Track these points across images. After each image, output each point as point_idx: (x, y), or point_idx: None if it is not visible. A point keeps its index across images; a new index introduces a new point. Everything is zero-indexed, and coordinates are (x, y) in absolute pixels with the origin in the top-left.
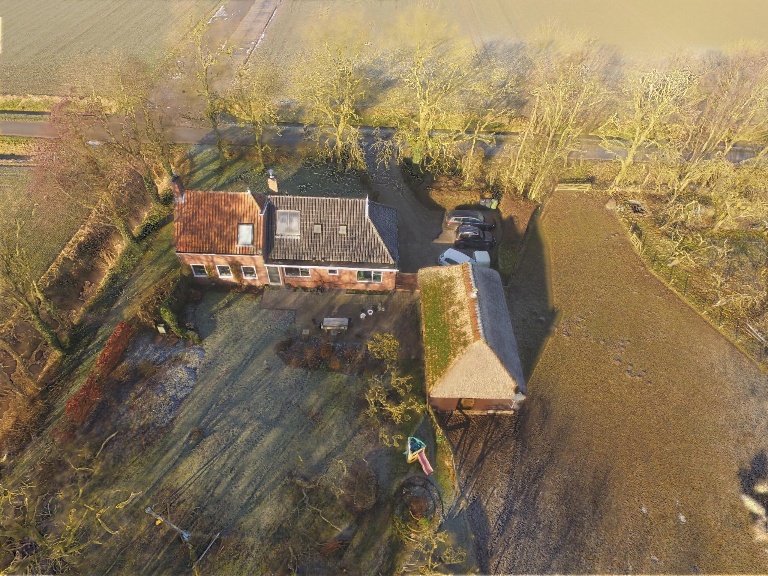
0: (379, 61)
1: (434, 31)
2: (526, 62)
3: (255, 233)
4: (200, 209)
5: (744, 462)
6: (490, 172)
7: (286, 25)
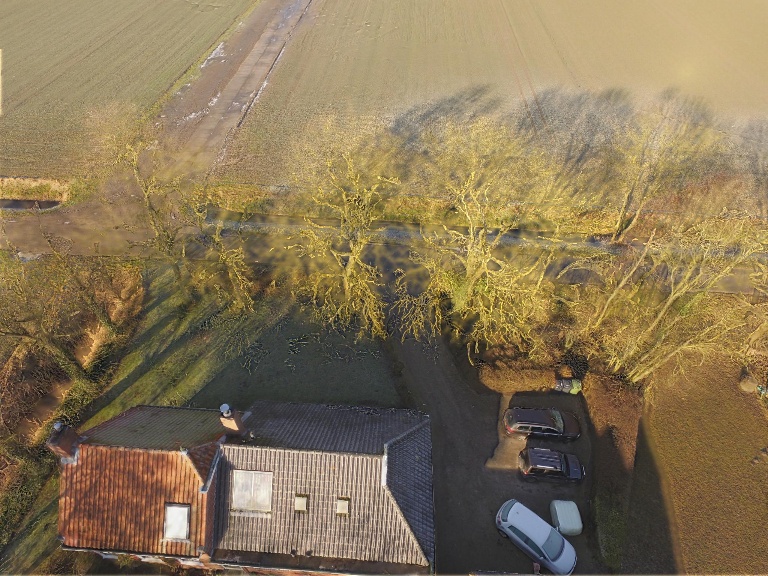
0: (405, 122)
1: (473, 77)
2: (592, 123)
3: (193, 519)
4: (103, 477)
5: None
6: (567, 332)
7: (294, 69)
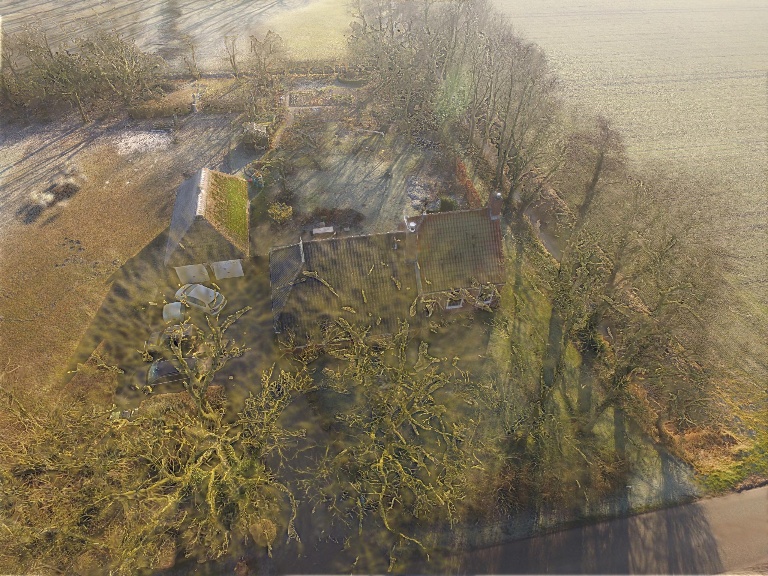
0: None
1: None
2: None
3: None
4: None
5: (40, 205)
6: (97, 465)
7: None
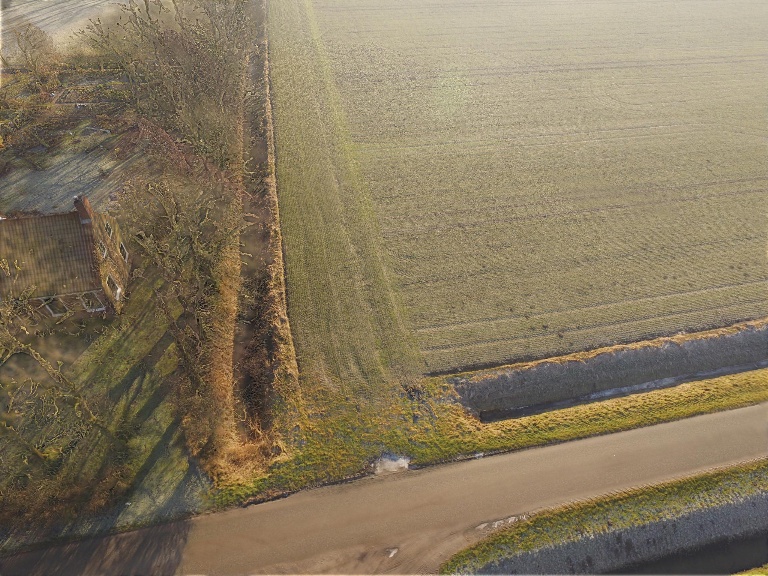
0: None
1: None
2: None
3: None
4: None
5: None
6: None
7: None
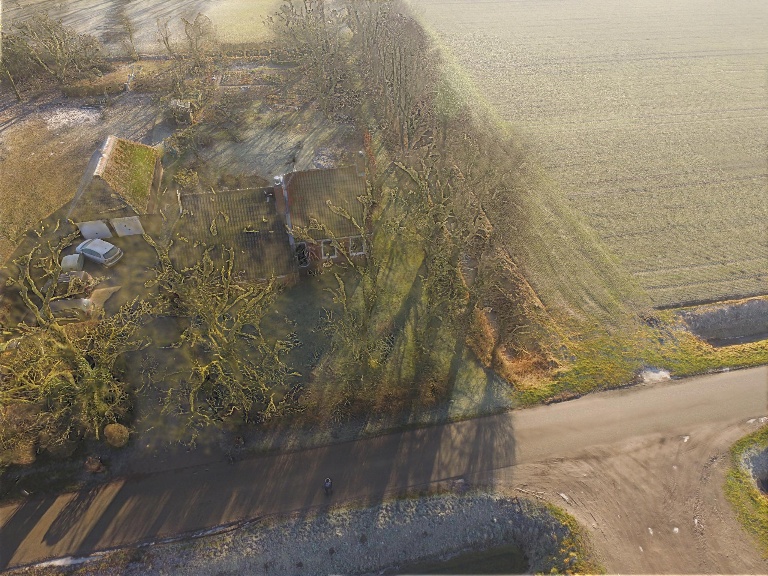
0: None
1: None
2: None
3: None
4: None
5: None
6: None
7: None
